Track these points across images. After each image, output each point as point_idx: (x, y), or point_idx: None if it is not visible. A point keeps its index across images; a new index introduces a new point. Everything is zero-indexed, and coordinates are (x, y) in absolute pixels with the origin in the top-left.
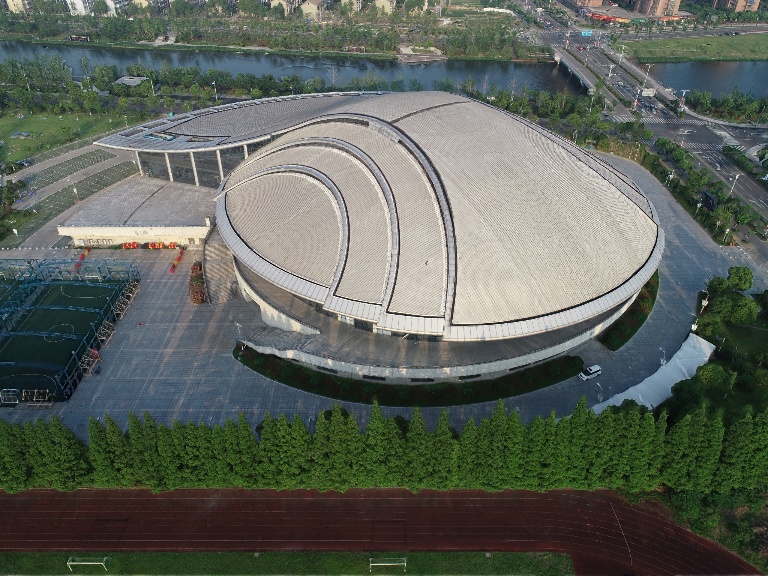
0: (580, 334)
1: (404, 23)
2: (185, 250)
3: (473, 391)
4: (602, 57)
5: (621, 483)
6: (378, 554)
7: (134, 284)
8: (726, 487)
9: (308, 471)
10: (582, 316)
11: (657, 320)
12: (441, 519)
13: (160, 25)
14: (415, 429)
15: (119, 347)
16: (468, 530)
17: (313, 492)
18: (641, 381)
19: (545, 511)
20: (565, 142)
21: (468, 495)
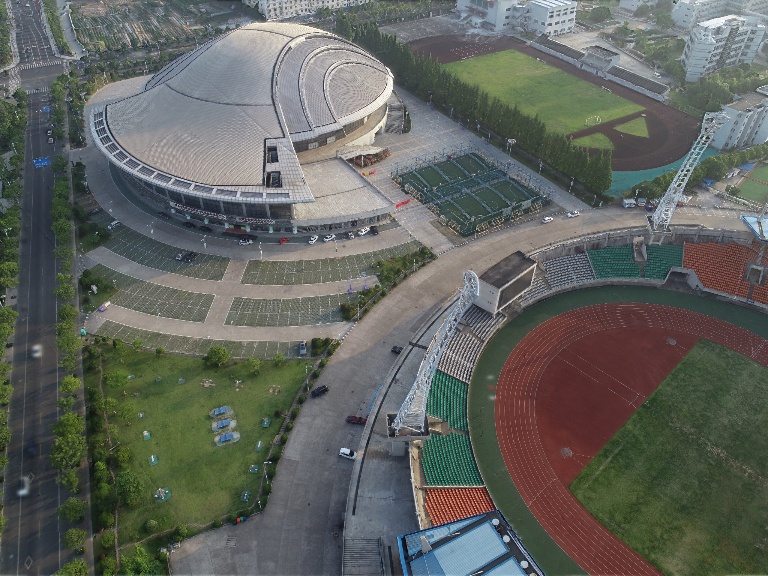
0: None
1: None
2: None
3: None
4: None
5: None
6: None
7: None
8: None
9: None
10: None
11: None
12: None
13: None
14: None
15: None
16: None
17: None
18: None
19: None
20: None
21: None
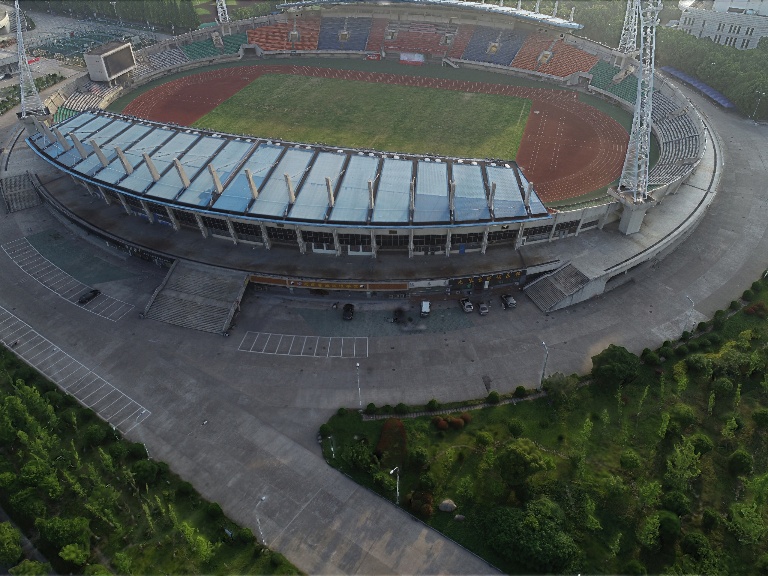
0: None
1: None
2: None
3: None
4: None
5: None
6: None
7: None
8: None
9: None
10: None
11: None
12: None
13: None
14: None
15: None
16: None
17: None
18: None
19: None
20: None
21: None
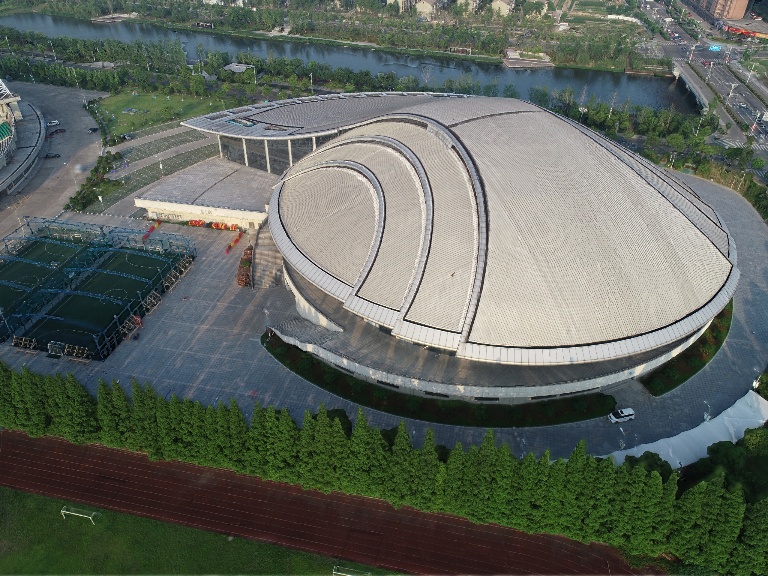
0: (616, 372)
1: (518, 27)
2: (244, 233)
3: (486, 414)
4: (729, 75)
5: (621, 542)
6: (346, 563)
7: (188, 260)
8: (744, 571)
9: (292, 466)
10: (615, 353)
11: (716, 370)
12: (419, 541)
13: (277, 16)
14: (399, 444)
15: (161, 317)
16: (444, 558)
17: (300, 488)
18: (676, 434)
19: (532, 555)
20: (639, 163)
21: (454, 522)
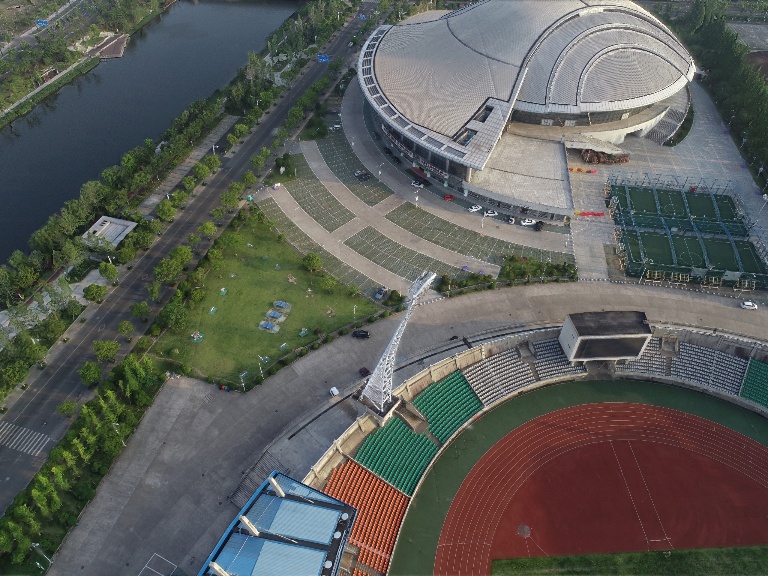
0: None
1: None
2: None
3: None
4: None
5: None
6: None
7: None
8: None
9: None
10: None
11: None
12: None
13: None
14: None
15: None
16: None
17: None
18: None
19: None
20: None
21: None
